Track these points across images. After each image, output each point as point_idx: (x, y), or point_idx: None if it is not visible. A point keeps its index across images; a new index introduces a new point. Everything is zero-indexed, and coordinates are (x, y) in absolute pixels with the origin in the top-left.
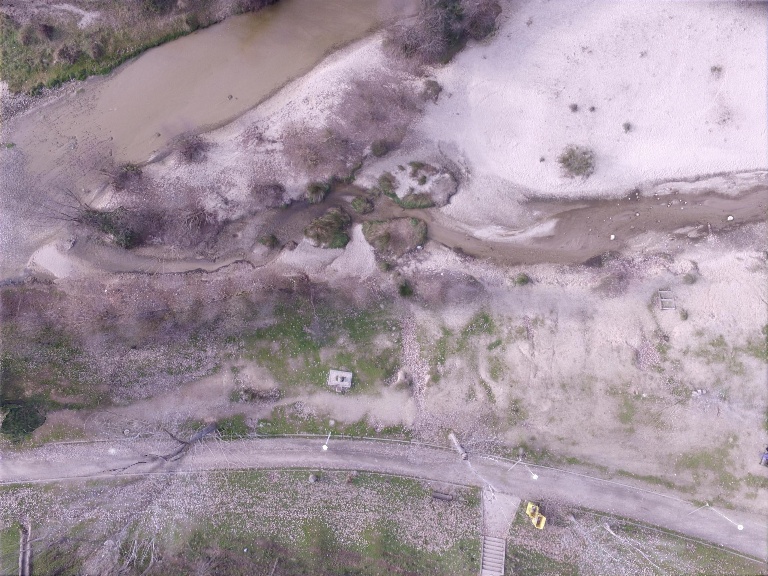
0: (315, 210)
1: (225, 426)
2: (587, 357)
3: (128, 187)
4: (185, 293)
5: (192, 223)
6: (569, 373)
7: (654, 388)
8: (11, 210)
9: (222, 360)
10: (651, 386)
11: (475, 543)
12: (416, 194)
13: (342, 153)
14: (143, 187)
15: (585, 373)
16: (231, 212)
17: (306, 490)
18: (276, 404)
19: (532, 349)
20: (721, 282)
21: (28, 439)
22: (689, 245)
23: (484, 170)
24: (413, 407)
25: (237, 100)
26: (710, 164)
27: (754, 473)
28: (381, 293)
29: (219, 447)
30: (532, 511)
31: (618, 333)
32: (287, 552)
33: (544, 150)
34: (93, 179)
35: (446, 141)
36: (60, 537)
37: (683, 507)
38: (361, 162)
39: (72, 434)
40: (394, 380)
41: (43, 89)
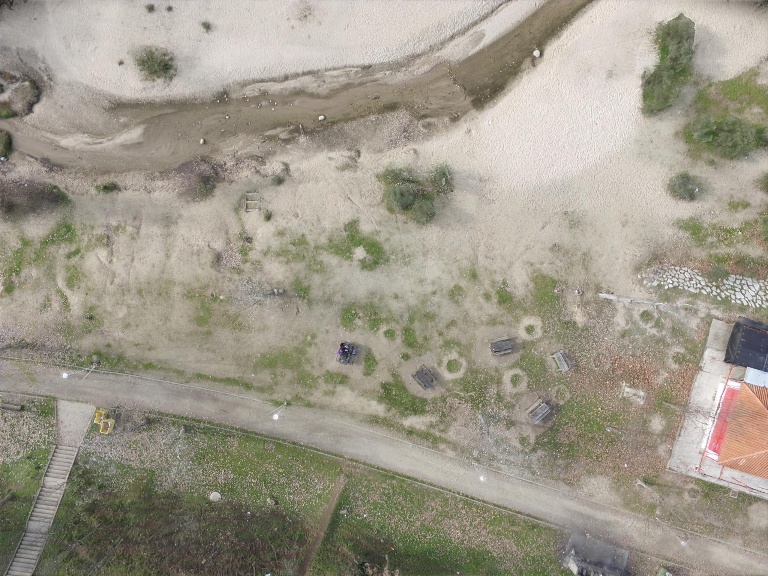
0: None
1: None
2: (167, 262)
3: None
4: None
5: None
6: (146, 278)
7: (232, 290)
8: None
9: None
10: (229, 288)
11: (45, 452)
12: None
13: None
14: None
15: (163, 278)
16: None
17: None
18: None
19: (111, 256)
20: (309, 182)
21: None
22: (281, 147)
23: (66, 77)
24: None
25: None
26: (296, 62)
27: (332, 370)
28: None
29: None
30: None
31: (201, 237)
32: None
33: (123, 53)
34: None
35: (25, 48)
36: None
37: (262, 407)
38: None
39: None
40: None
41: None
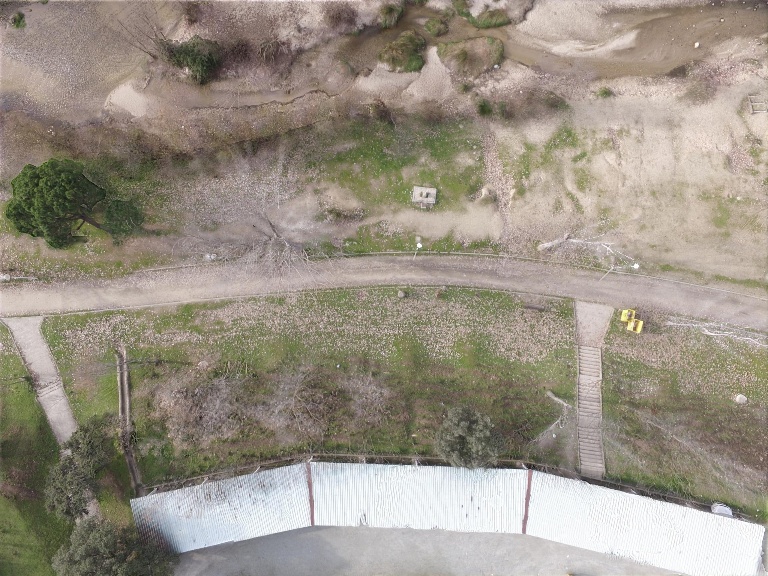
0: (388, 35)
1: (311, 246)
2: (676, 164)
3: (200, 20)
4: (261, 125)
5: (266, 52)
6: (659, 180)
7: (749, 191)
8: (86, 52)
9: (304, 184)
10: (745, 189)
11: (570, 352)
12: (491, 11)
13: None
14: (215, 19)
15: (675, 180)
16: (304, 41)
17: (395, 307)
18: (361, 223)
19: (619, 159)
20: None
21: (118, 267)
22: None
23: None
24: (499, 221)
25: None
26: None
27: None
28: (459, 114)
29: (306, 268)
30: (627, 317)
31: (708, 139)
32: (380, 367)
33: None
34: (164, 17)
35: None
36: (155, 359)
37: None
38: None
39: (160, 260)
40: (478, 196)
41: None
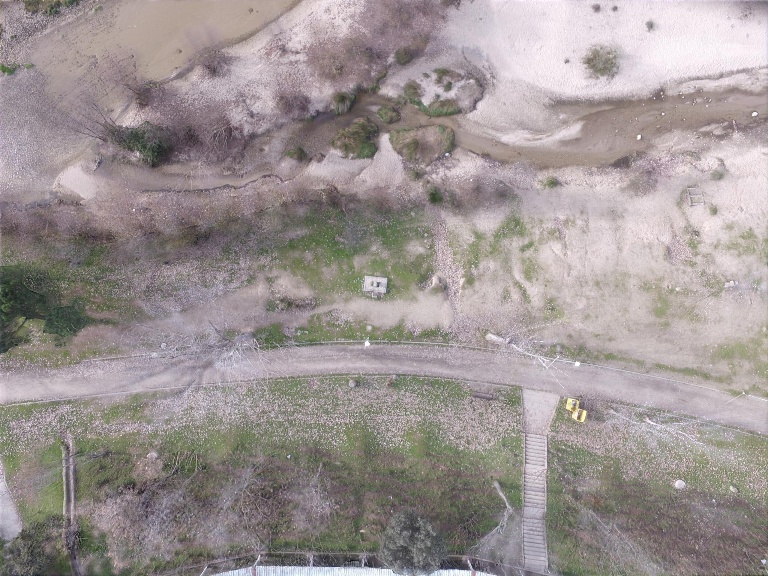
0: (341, 121)
1: (262, 336)
2: (619, 254)
3: (152, 104)
4: (214, 209)
5: (218, 137)
6: (602, 270)
7: (687, 281)
8: (33, 132)
9: (256, 271)
10: (684, 280)
11: (517, 440)
12: (442, 100)
13: (366, 62)
14: (167, 103)
15: (618, 270)
16: (257, 126)
17: (346, 396)
18: (312, 312)
19: (565, 249)
20: (748, 177)
21: (64, 356)
22: (715, 142)
23: (509, 75)
24: (449, 310)
25: (258, 13)
26: (733, 60)
27: None
28: (411, 201)
29: (257, 357)
30: (572, 406)
31: (649, 230)
32: (330, 457)
33: (568, 51)
34: (115, 98)
35: (470, 47)
36: (102, 451)
37: (720, 397)
38: (386, 71)
39: (109, 350)
40: (429, 285)
41: (60, 8)
